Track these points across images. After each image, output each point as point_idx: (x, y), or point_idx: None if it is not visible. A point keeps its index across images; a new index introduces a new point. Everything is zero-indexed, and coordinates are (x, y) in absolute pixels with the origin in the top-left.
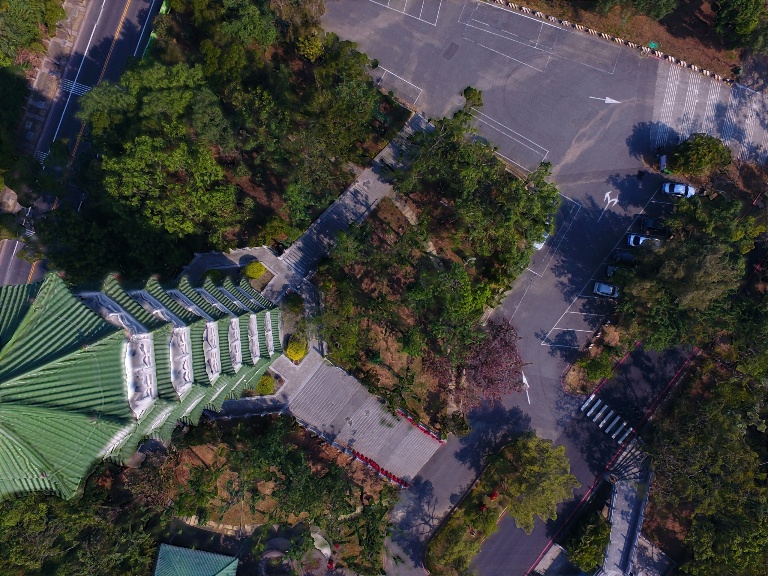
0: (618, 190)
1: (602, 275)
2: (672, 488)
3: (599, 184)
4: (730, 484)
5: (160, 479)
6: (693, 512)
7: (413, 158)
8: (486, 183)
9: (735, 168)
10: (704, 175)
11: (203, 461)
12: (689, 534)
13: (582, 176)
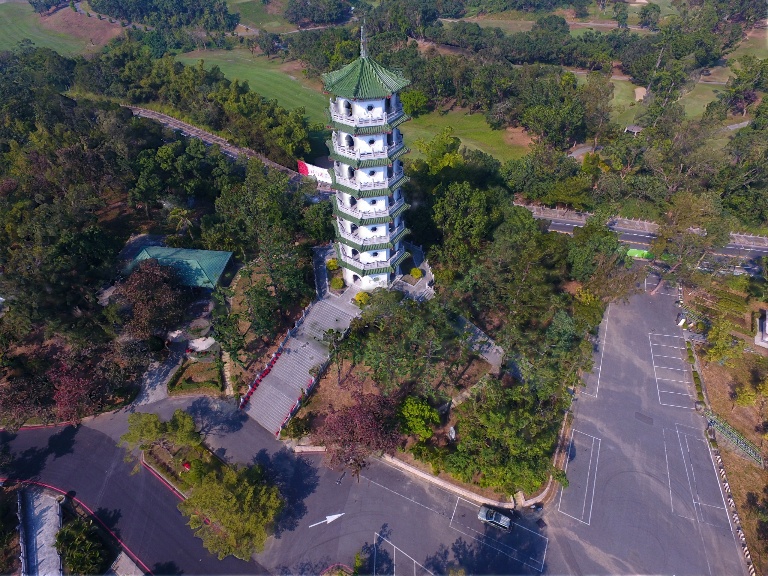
0: None
1: None
2: None
3: None
4: None
5: None
6: None
7: None
8: None
9: None
10: None
11: None
12: None
13: (577, 570)
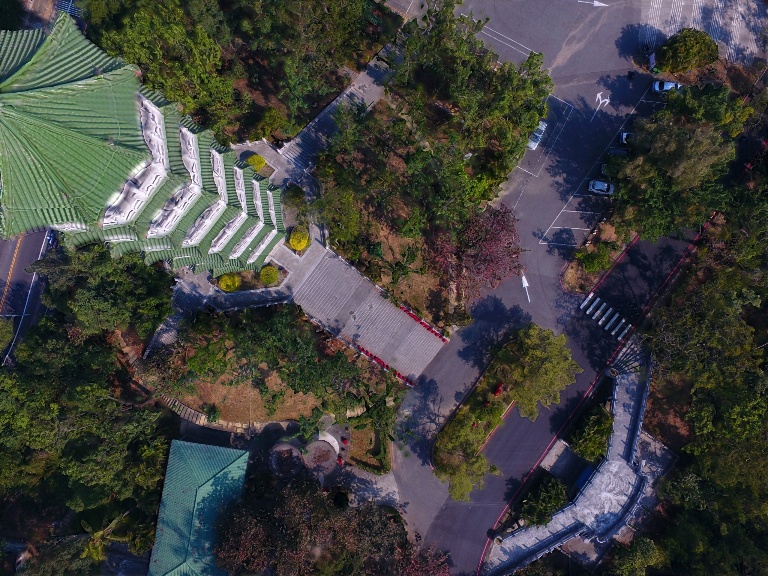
0: (609, 91)
1: (596, 174)
2: (671, 365)
3: (590, 85)
4: (728, 357)
5: (169, 374)
6: (693, 387)
7: None
8: (480, 74)
9: (723, 67)
10: (693, 74)
11: None
12: (690, 409)
13: (573, 78)
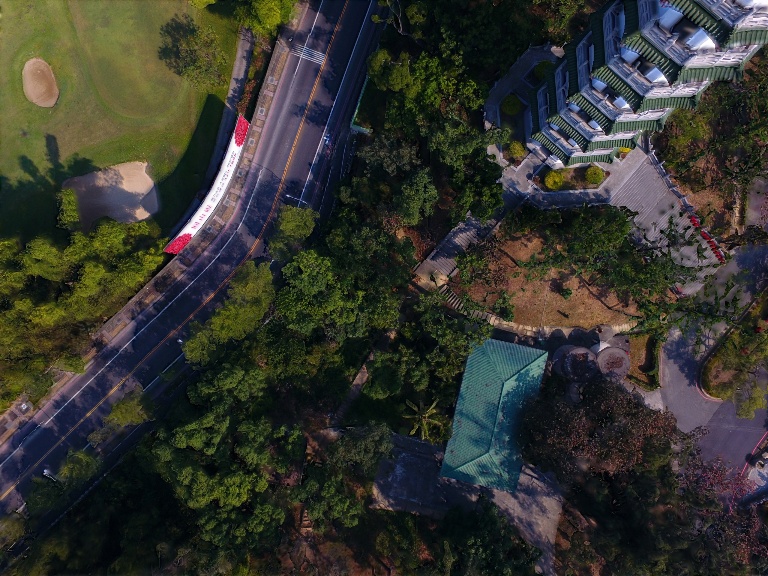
0: None
1: None
2: None
3: None
4: None
5: None
6: None
7: None
8: None
9: None
10: None
11: (513, 259)
12: None
13: None
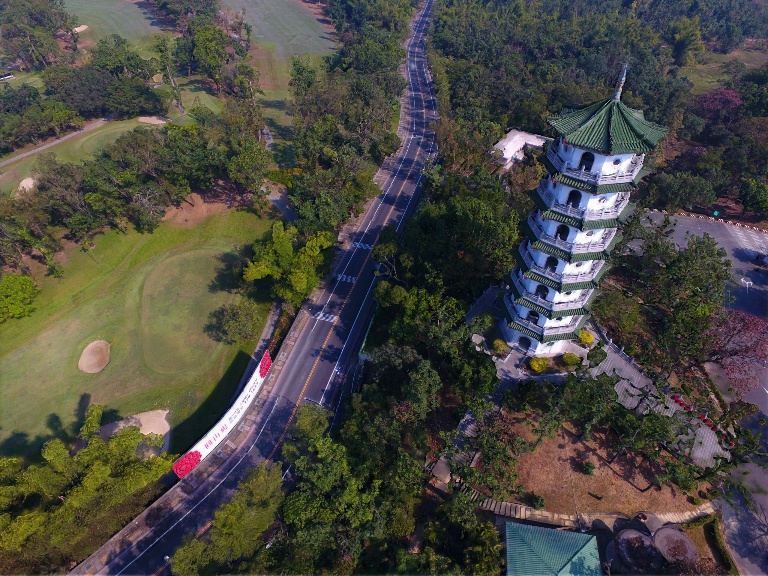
0: (748, 278)
1: None
2: None
3: None
4: None
5: None
6: None
7: None
8: None
9: None
10: None
11: None
12: None
13: None
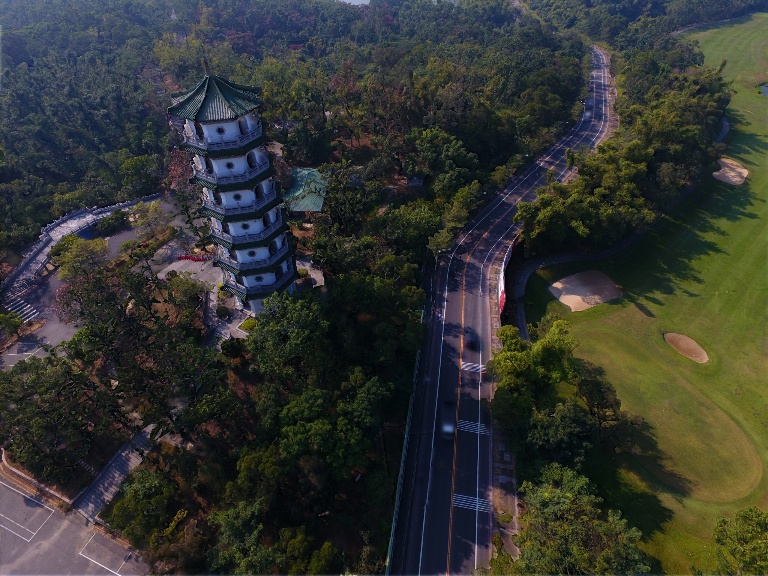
0: None
1: None
2: None
3: None
4: None
5: None
6: None
7: (110, 464)
8: None
9: None
10: None
11: None
12: None
13: None
